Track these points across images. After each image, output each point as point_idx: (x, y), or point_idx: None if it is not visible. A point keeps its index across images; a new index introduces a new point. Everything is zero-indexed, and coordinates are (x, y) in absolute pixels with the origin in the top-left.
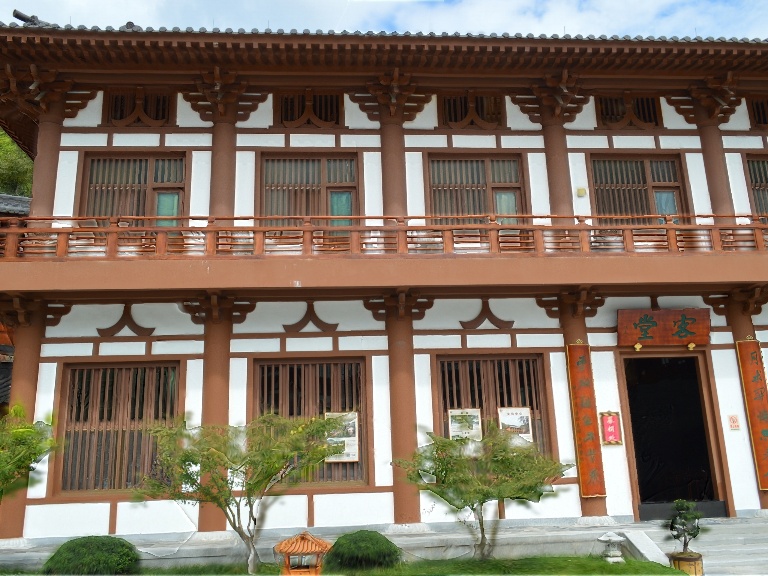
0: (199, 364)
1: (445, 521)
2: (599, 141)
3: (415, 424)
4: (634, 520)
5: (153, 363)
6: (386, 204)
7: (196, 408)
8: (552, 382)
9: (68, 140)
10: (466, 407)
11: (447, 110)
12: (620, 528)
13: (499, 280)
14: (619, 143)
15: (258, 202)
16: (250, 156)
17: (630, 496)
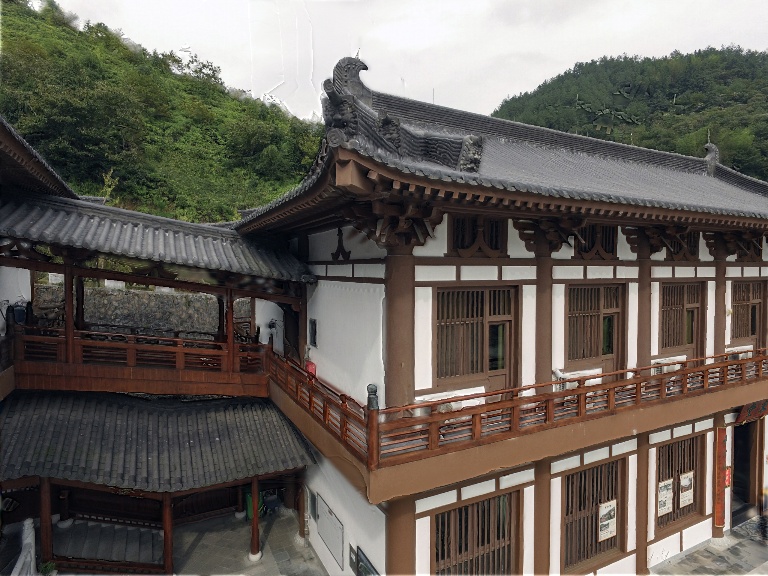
0: (532, 490)
1: (658, 563)
2: (738, 271)
3: (647, 501)
4: (730, 531)
5: (498, 495)
6: (641, 330)
7: (531, 528)
8: (707, 453)
9: (422, 274)
10: (665, 478)
11: (671, 243)
12: (763, 561)
13: (728, 406)
14: (746, 273)
15: (567, 334)
16: (562, 289)
17: (730, 517)
